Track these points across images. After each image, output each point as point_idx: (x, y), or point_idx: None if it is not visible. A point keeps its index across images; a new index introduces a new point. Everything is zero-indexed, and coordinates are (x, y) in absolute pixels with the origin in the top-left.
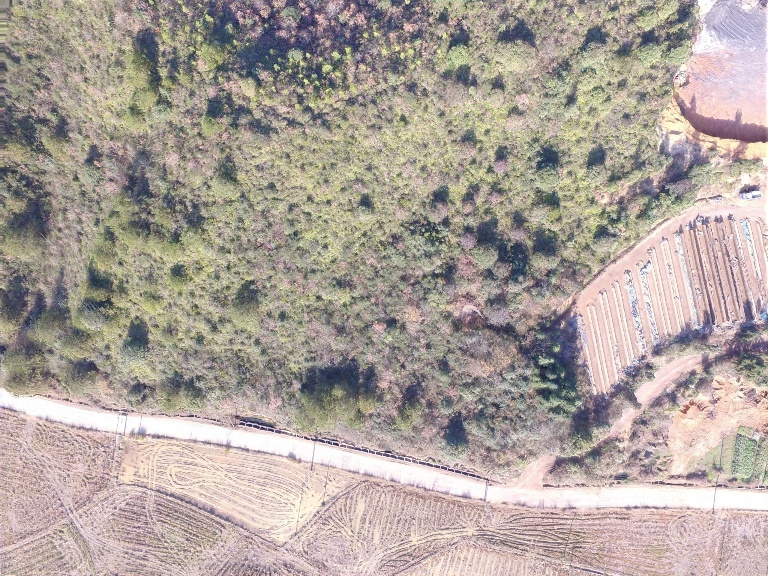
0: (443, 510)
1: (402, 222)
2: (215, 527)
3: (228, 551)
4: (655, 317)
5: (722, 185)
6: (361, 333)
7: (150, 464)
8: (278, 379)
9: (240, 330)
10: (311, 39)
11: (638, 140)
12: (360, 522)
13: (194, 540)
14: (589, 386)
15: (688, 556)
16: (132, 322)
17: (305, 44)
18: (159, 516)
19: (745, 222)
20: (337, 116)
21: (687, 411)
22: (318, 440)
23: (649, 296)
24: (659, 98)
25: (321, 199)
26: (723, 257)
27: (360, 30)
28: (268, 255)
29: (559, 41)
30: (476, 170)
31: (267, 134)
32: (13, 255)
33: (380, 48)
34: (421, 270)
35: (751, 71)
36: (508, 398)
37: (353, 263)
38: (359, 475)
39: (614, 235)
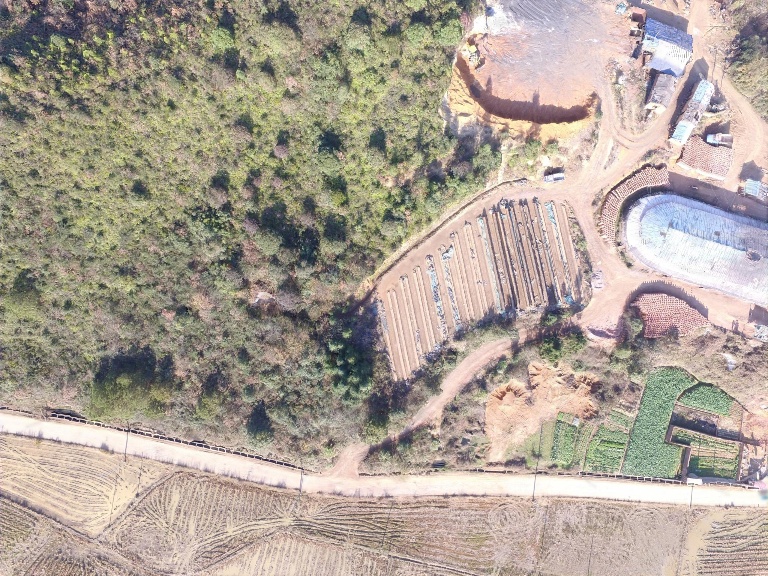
0: (259, 500)
1: (185, 208)
2: (28, 520)
3: (41, 544)
4: (457, 302)
5: (524, 168)
6: (151, 321)
7: None
8: (72, 369)
9: (23, 319)
10: (78, 25)
11: (419, 122)
12: (175, 513)
13: (7, 533)
14: (388, 372)
15: (509, 544)
16: None
17: (71, 30)
18: None
19: (550, 205)
20: (98, 101)
21: (503, 397)
22: (131, 431)
23: (451, 281)
24: (436, 79)
25: (89, 186)
26: (527, 240)
27: (131, 15)
28: (39, 243)
29: (324, 23)
30: (255, 155)
31: (20, 120)
32: None
33: (146, 33)
34: (207, 257)
35: (549, 52)
36: (306, 385)
37: (134, 250)
38: (173, 466)
39: (398, 219)
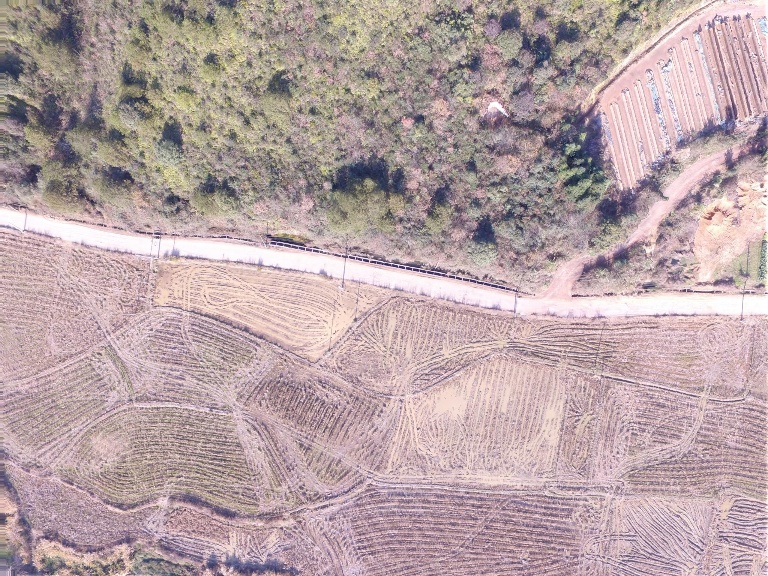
0: (474, 324)
1: (427, 14)
2: (250, 346)
3: (263, 369)
4: (678, 114)
5: None
6: (390, 130)
7: (184, 286)
8: (309, 181)
9: (272, 125)
10: None
11: None
12: (392, 337)
13: (229, 359)
14: (615, 180)
15: (718, 363)
16: (166, 123)
17: None
18: (194, 336)
19: (763, 20)
20: None
21: (712, 217)
22: (348, 257)
23: (671, 94)
24: None
25: None
26: (743, 54)
27: None
28: (298, 40)
29: None
30: None
31: None
32: (48, 71)
33: None
34: (447, 63)
35: None
36: (536, 195)
37: (381, 54)
38: (390, 290)
39: (636, 19)
